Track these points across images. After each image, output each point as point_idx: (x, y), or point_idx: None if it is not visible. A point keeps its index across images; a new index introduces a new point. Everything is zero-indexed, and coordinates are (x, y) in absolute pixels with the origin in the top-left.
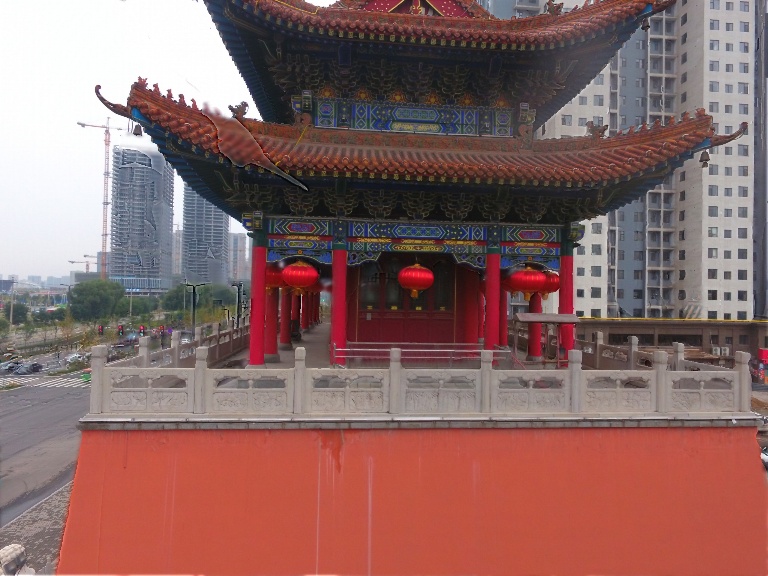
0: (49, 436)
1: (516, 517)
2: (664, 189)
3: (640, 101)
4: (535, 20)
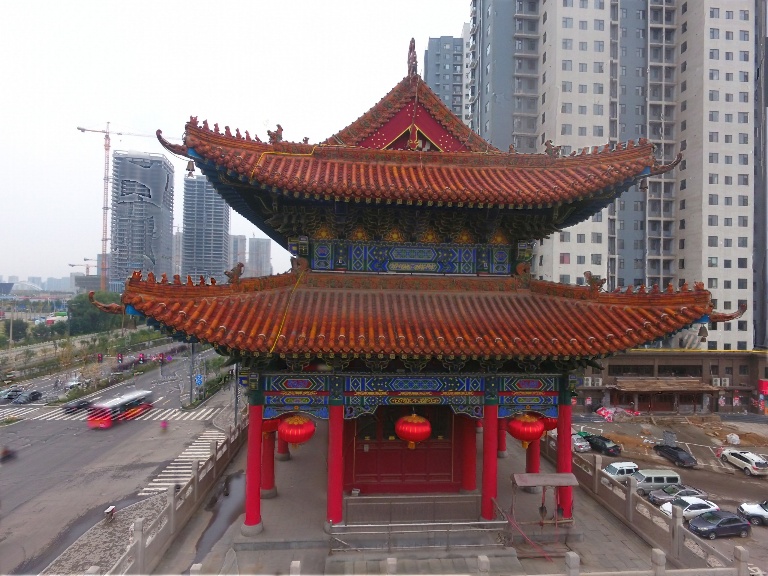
0: (48, 486)
1: None
2: (664, 217)
3: (640, 128)
4: (533, 159)
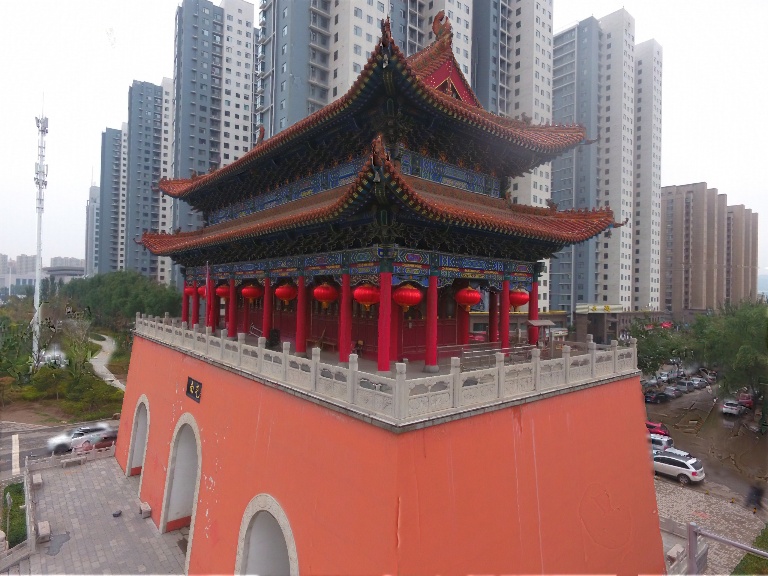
0: None
1: (583, 441)
2: None
3: None
4: (515, 122)
